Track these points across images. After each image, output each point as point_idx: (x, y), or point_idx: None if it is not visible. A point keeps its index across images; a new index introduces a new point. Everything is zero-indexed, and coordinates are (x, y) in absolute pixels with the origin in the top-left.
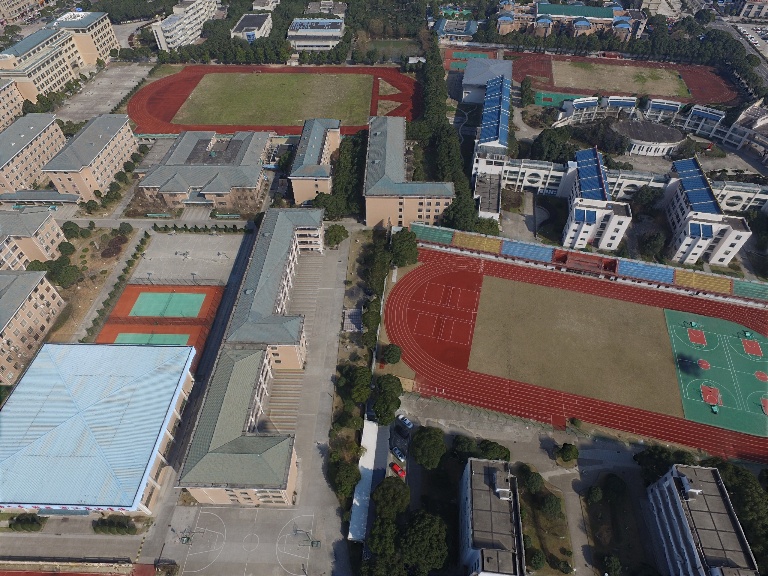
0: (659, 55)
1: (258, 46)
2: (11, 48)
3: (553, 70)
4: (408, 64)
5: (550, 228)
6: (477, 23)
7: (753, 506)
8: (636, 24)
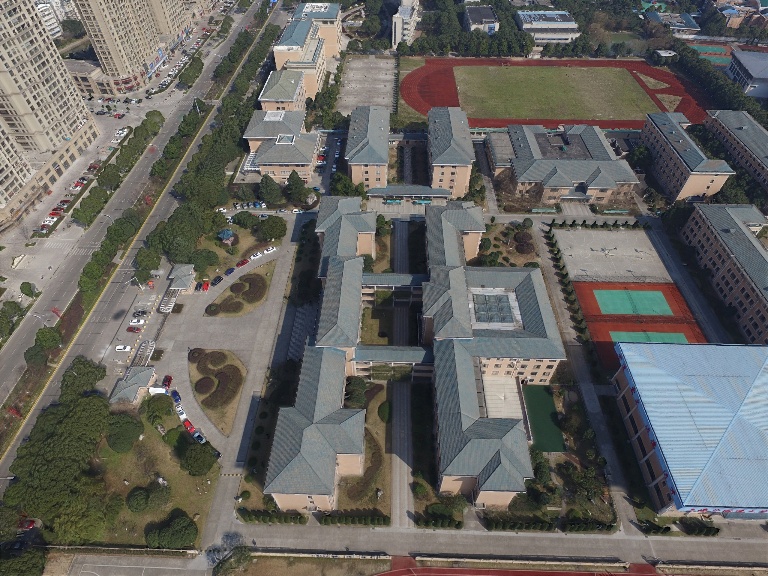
0: None
1: (501, 38)
2: (290, 39)
3: None
4: (664, 57)
5: None
6: (691, 16)
7: None
8: None
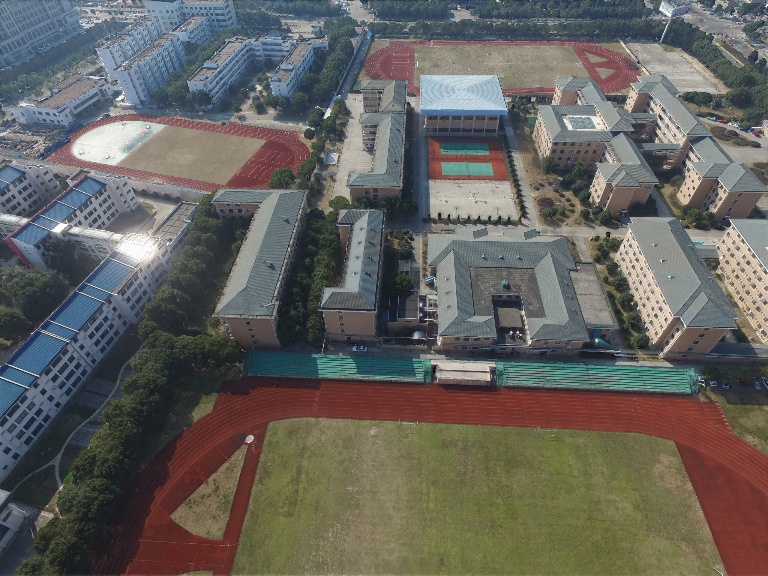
0: None
1: None
2: None
3: None
4: None
5: None
6: None
7: (182, 83)
8: None
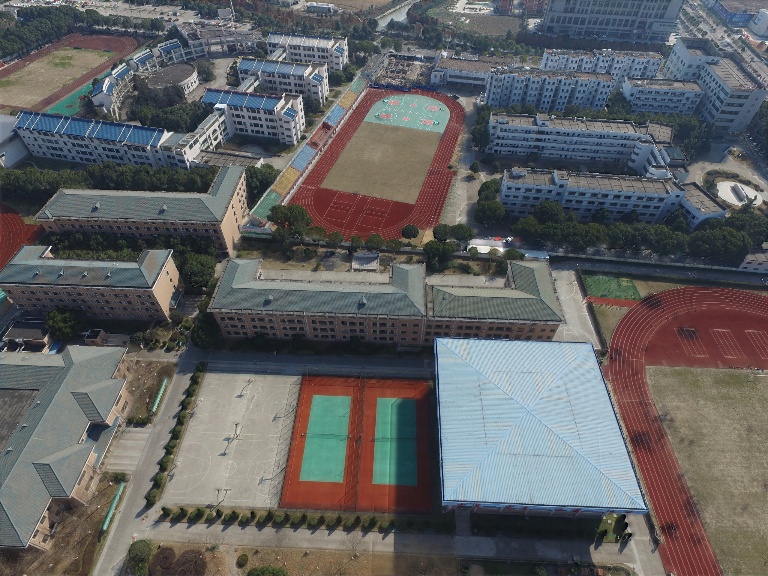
0: (33, 44)
1: None
2: None
3: None
4: None
5: (271, 147)
6: None
7: None
8: None
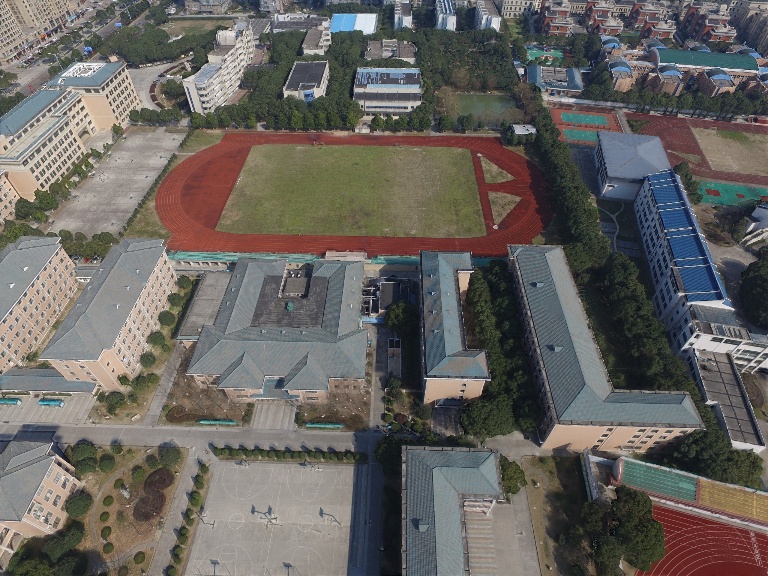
0: None
1: (319, 109)
2: (1, 123)
3: (699, 143)
4: (516, 136)
5: None
6: (579, 71)
7: None
8: None
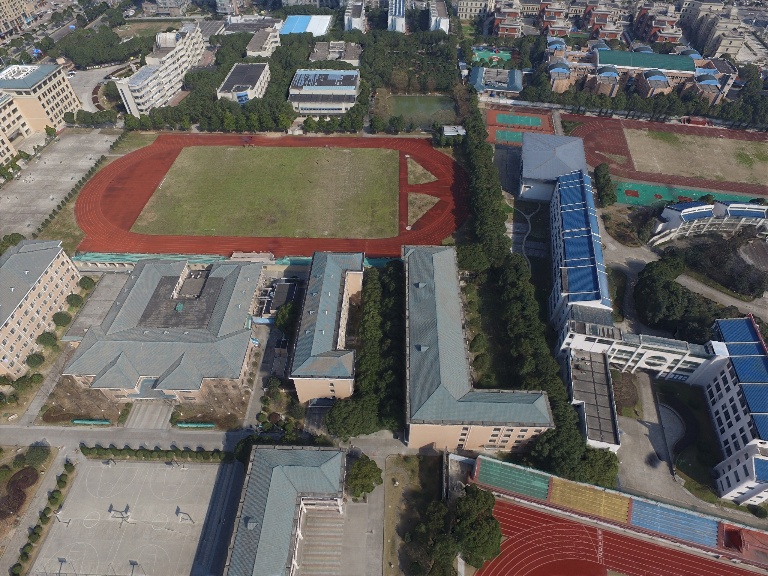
0: (762, 124)
1: (251, 110)
2: None
3: (628, 144)
4: (444, 138)
5: (691, 454)
6: (522, 73)
7: None
8: (724, 79)
